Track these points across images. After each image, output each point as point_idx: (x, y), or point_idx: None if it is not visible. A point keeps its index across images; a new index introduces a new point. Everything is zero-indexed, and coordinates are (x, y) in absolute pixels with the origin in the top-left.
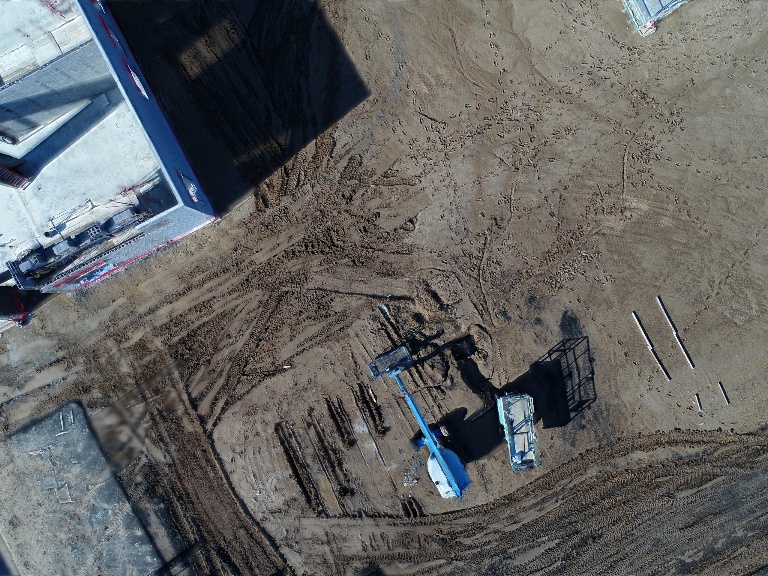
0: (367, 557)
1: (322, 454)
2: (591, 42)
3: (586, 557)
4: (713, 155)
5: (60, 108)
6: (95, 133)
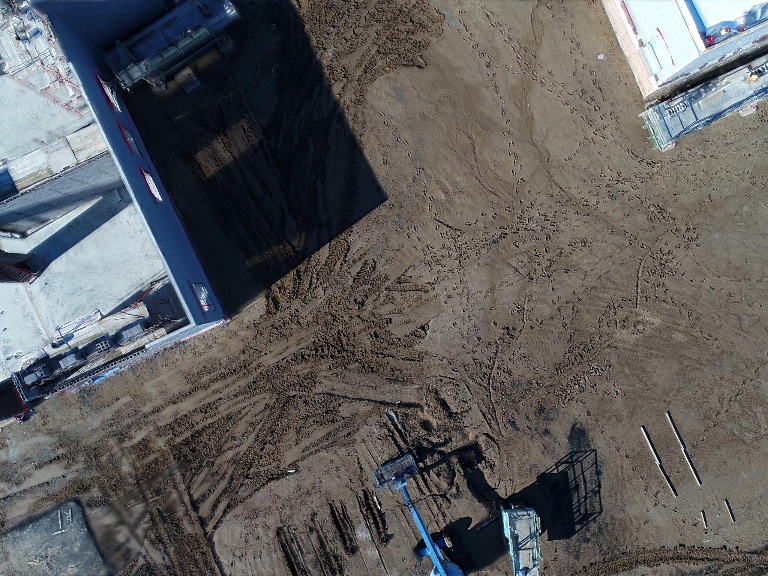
0: None
1: (324, 560)
2: (610, 155)
3: None
4: (727, 272)
5: (71, 205)
6: (105, 229)
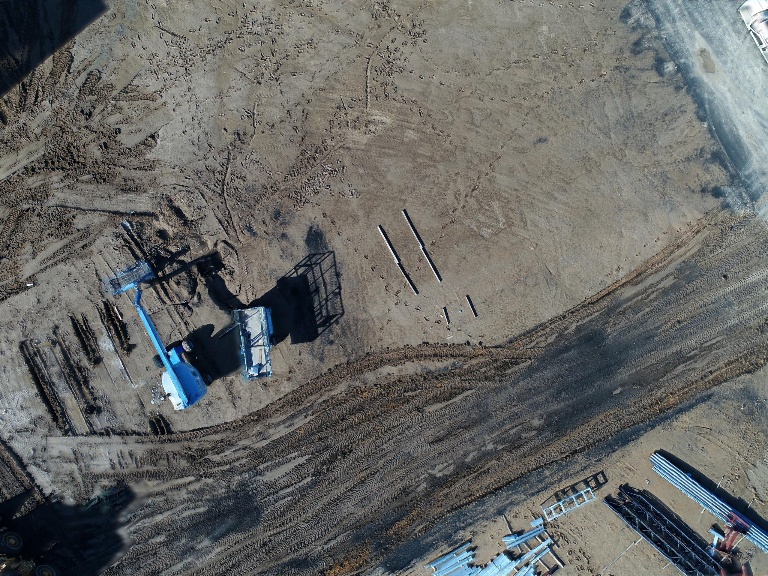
0: (115, 475)
1: (68, 372)
2: None
3: (337, 473)
4: (456, 67)
5: None
6: None
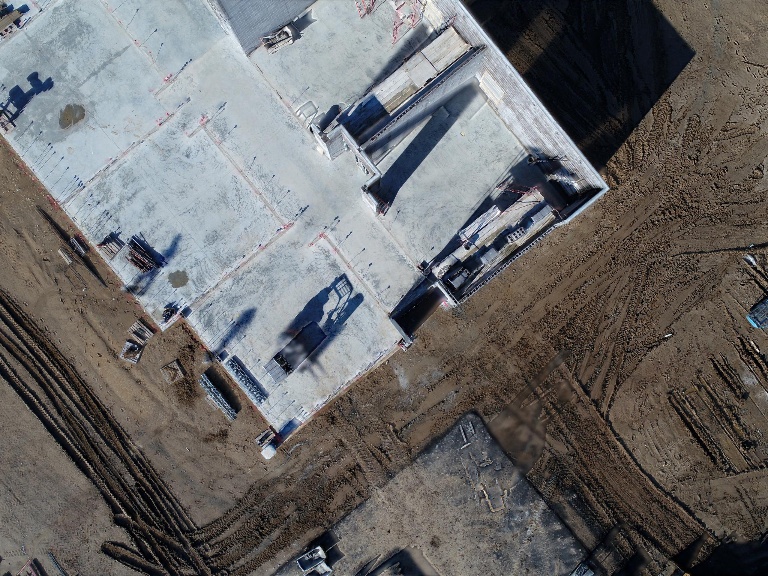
0: None
1: (718, 413)
2: None
3: None
4: None
5: (411, 128)
6: (442, 146)
